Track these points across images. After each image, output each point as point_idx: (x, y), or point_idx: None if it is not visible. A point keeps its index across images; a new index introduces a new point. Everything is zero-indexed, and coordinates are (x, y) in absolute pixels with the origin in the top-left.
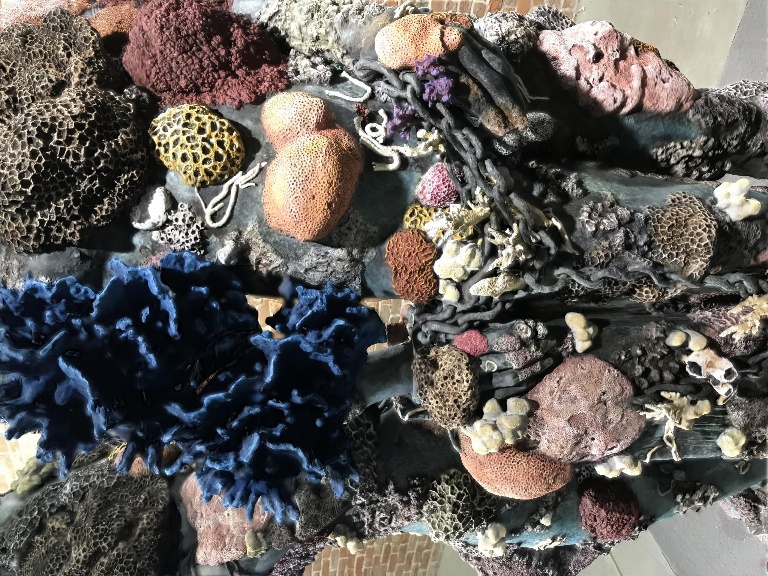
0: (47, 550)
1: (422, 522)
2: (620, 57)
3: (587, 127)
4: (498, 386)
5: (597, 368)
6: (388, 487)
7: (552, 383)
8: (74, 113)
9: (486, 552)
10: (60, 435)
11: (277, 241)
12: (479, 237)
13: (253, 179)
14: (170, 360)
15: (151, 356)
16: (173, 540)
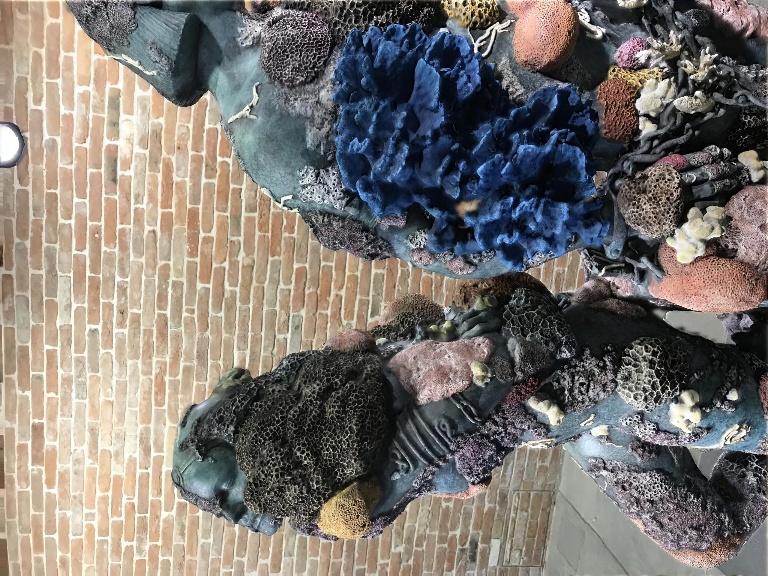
0: (273, 401)
1: (616, 396)
2: (737, 3)
3: (722, 46)
4: (698, 196)
5: None
6: (584, 353)
7: (739, 201)
8: None
9: (682, 422)
10: (403, 132)
11: (521, 75)
12: (671, 77)
13: (506, 28)
14: (466, 116)
15: (470, 84)
16: (389, 397)
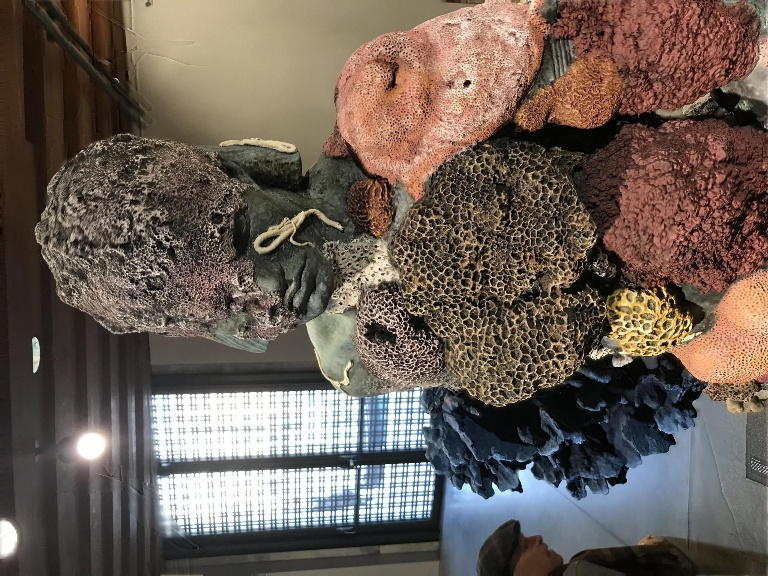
0: None
1: None
2: None
3: None
4: (763, 388)
5: None
6: None
7: None
8: (568, 366)
9: None
10: None
11: None
12: None
13: None
14: None
15: None
16: None
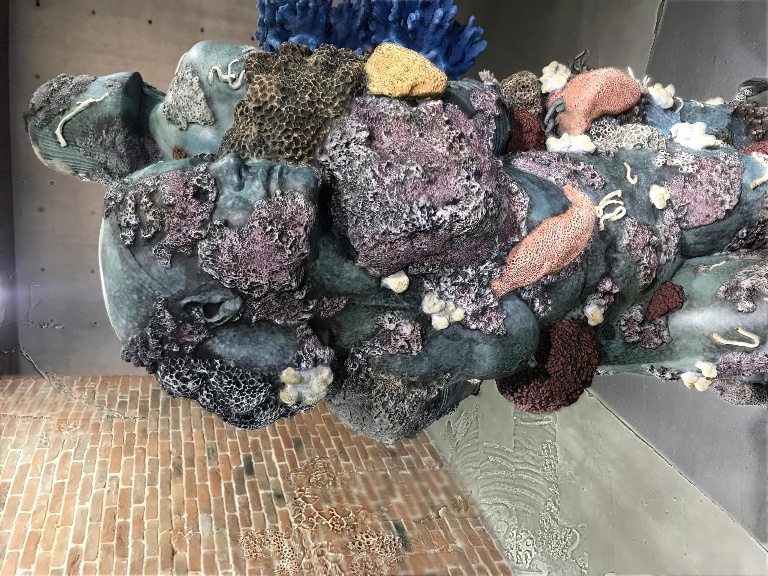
0: None
1: None
2: None
3: None
4: None
5: None
6: None
7: None
8: None
9: None
10: None
11: None
12: None
13: None
14: None
15: None
16: None
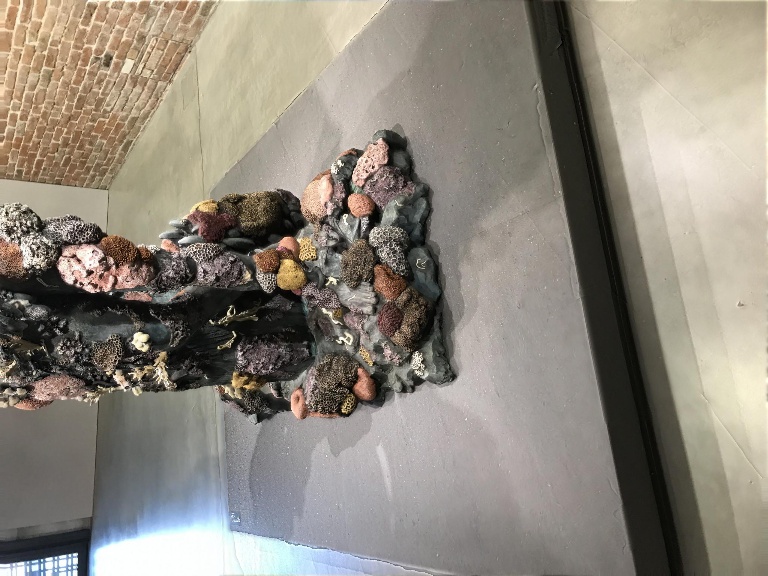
0: None
1: None
2: (105, 270)
3: None
4: None
5: (66, 379)
6: None
7: (42, 383)
8: None
9: None
10: None
11: None
12: None
13: None
14: None
15: None
16: None
